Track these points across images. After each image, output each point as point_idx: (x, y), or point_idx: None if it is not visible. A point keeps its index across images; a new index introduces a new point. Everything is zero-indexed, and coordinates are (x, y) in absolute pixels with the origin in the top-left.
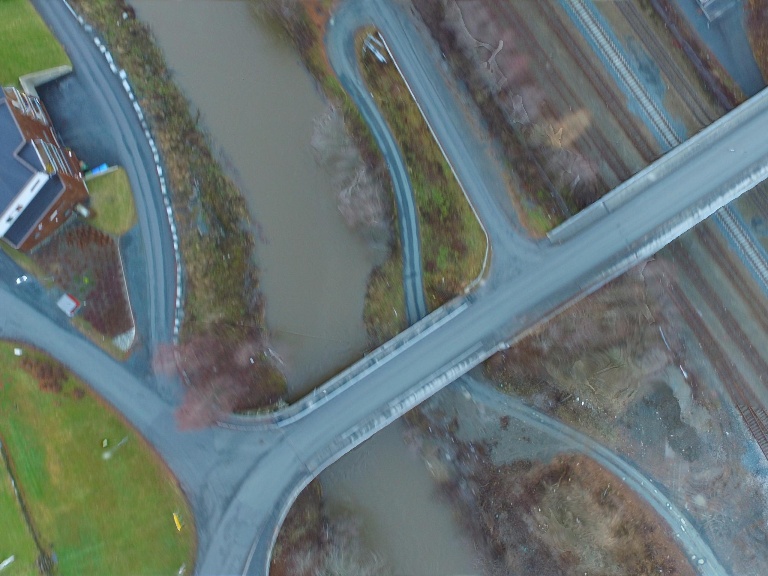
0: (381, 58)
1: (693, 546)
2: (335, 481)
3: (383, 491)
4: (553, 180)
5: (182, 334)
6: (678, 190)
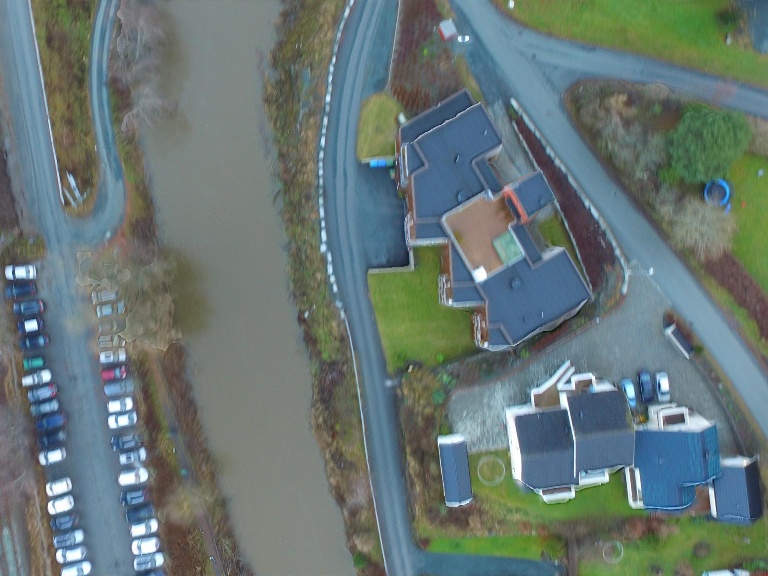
0: (72, 179)
1: None
2: None
3: None
4: None
5: None
6: None
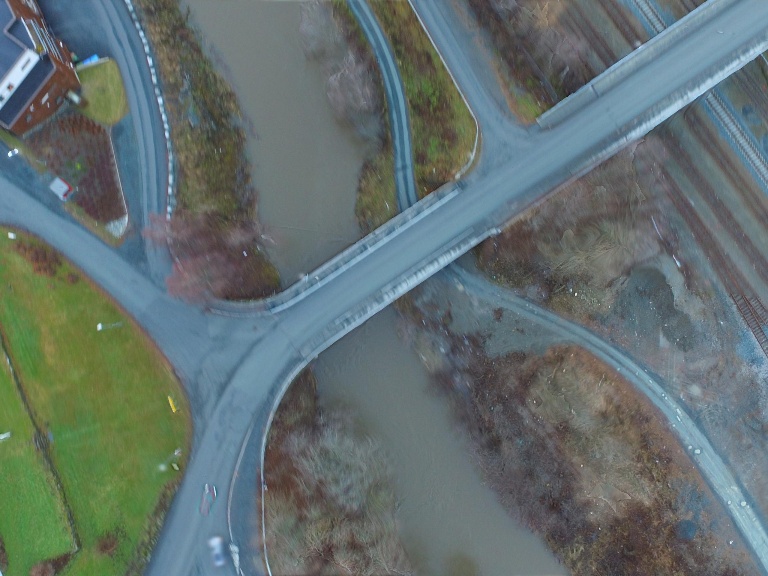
0: None
1: (689, 436)
2: (330, 375)
3: (378, 385)
4: (542, 67)
5: (174, 221)
6: (667, 72)
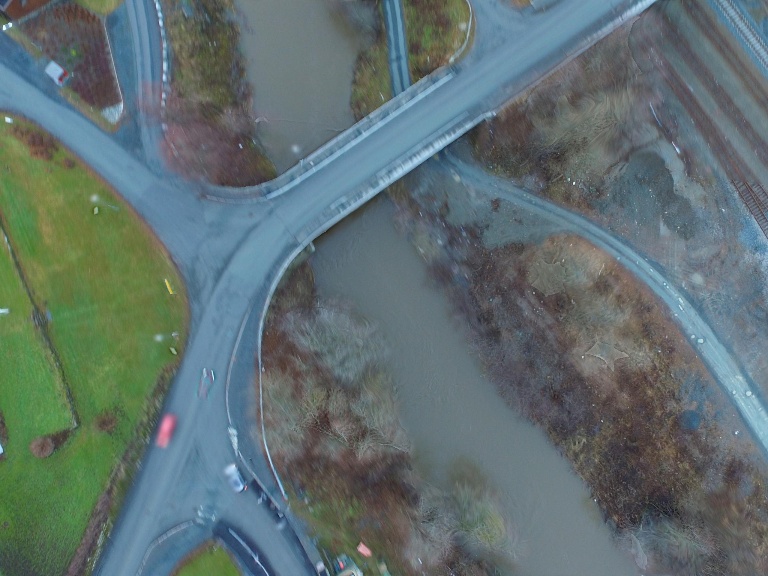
0: None
1: (692, 325)
2: (327, 269)
3: (375, 277)
4: None
5: (169, 108)
6: None
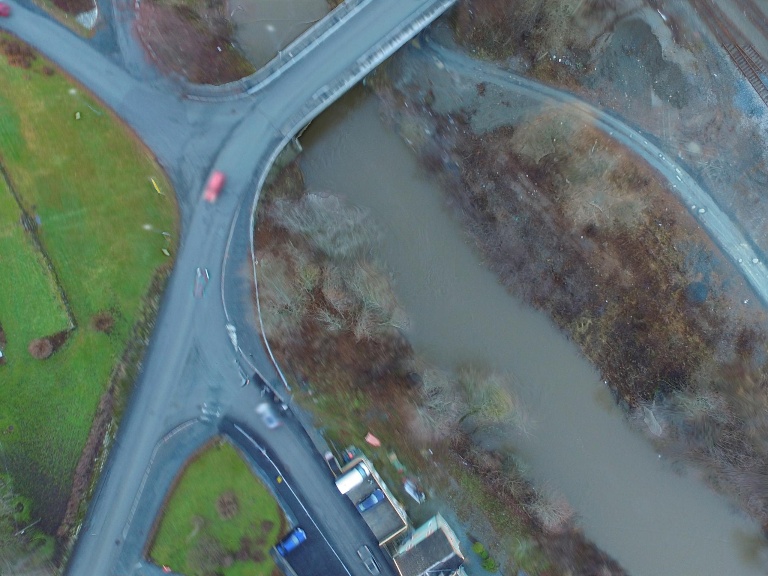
0: None
1: (691, 195)
2: (316, 168)
3: (365, 173)
4: None
5: (144, 10)
6: None
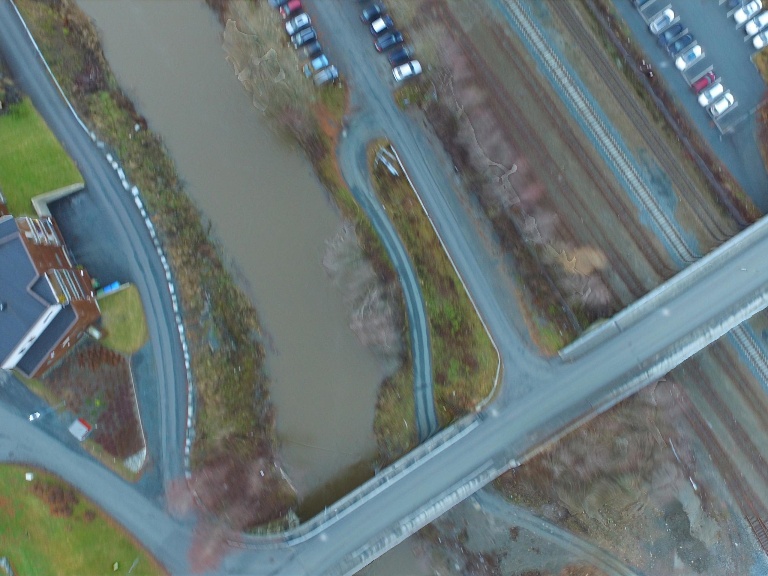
0: (393, 171)
1: None
2: None
3: None
4: (565, 296)
5: (193, 454)
6: (690, 309)
